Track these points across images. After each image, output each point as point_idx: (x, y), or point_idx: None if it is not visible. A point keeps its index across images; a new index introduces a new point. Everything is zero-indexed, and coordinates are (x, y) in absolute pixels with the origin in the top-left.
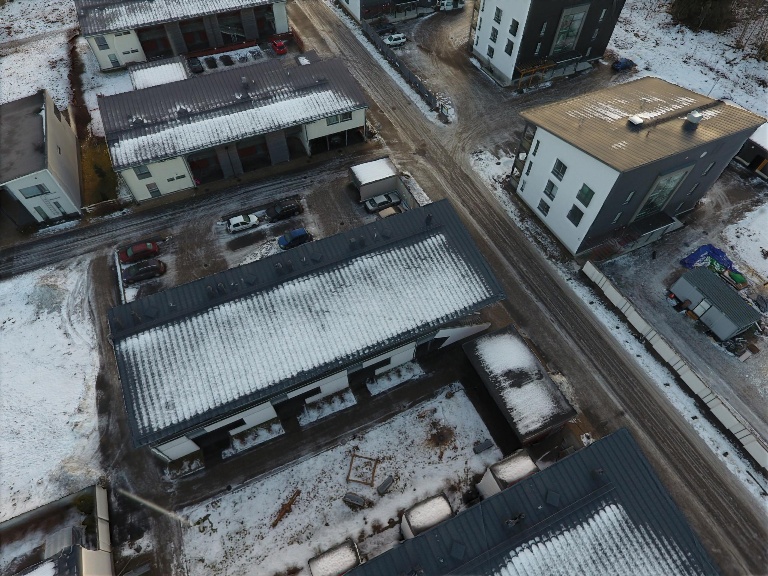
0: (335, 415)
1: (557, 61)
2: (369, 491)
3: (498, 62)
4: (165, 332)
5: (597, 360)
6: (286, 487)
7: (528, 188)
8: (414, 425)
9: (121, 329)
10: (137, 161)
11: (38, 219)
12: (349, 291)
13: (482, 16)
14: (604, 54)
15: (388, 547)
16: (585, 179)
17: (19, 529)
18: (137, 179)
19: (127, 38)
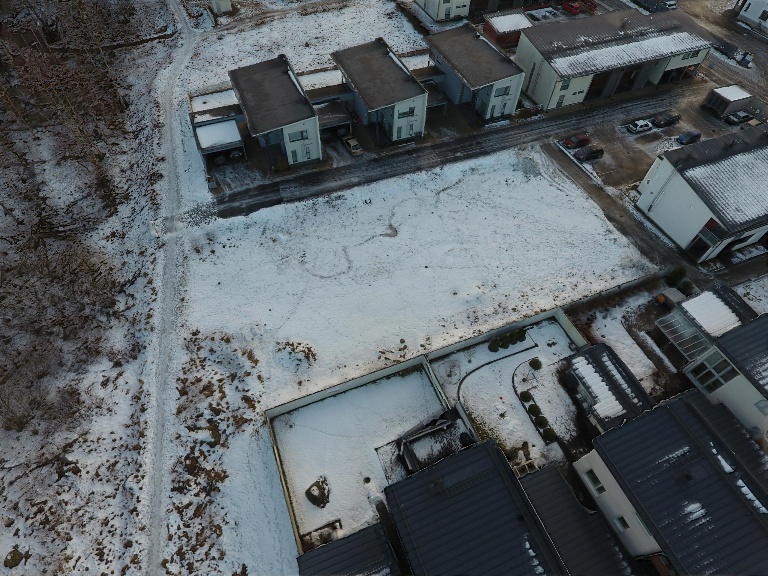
0: None
1: None
2: None
3: None
4: (710, 168)
5: None
6: None
7: None
8: None
9: None
10: (574, 73)
11: (487, 116)
12: None
13: None
14: None
15: None
16: None
17: (629, 291)
18: (559, 90)
19: None
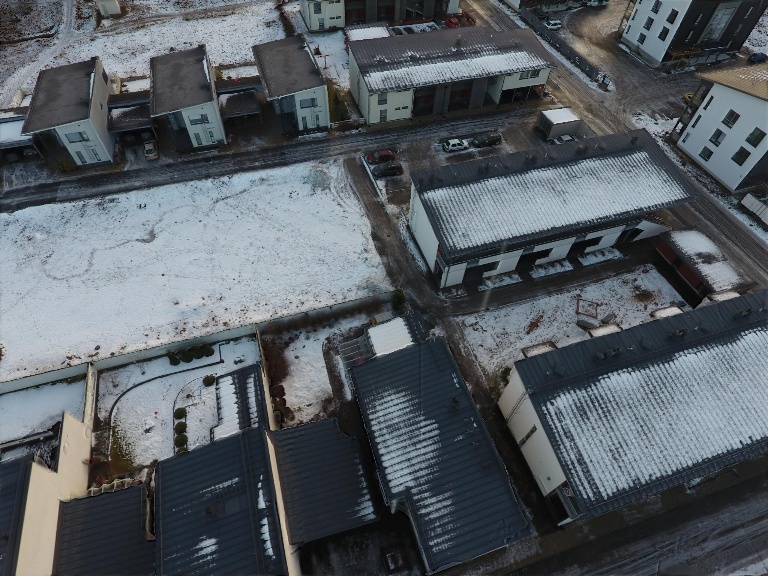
0: (558, 274)
1: (704, 48)
2: (595, 321)
3: (648, 47)
4: (453, 191)
5: (761, 262)
6: (531, 312)
7: (691, 139)
8: (621, 287)
9: (422, 185)
10: (385, 88)
11: (300, 127)
12: (580, 181)
13: (638, 8)
14: (740, 49)
15: (656, 318)
16: (758, 123)
17: (348, 312)
18: (377, 104)
19: (337, 6)
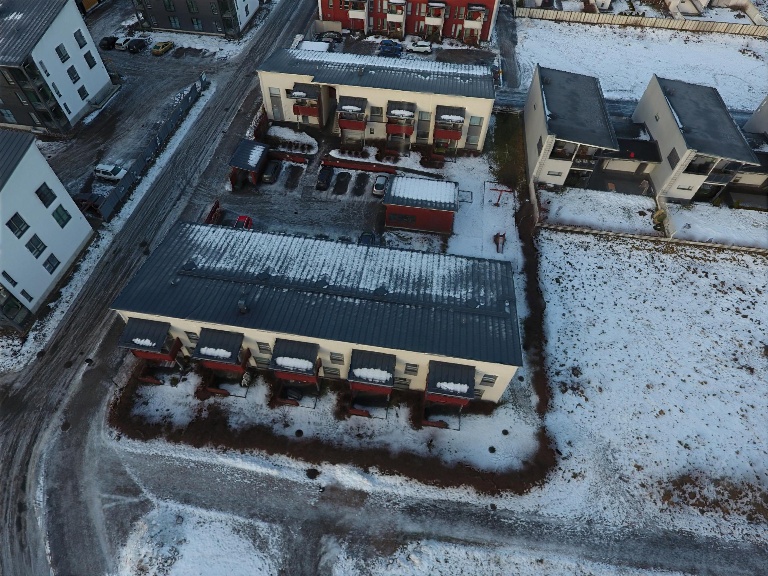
0: None
1: None
2: None
3: (93, 88)
4: None
5: None
6: None
7: None
8: None
9: None
10: None
11: None
12: None
13: (52, 80)
14: None
15: None
16: None
17: None
18: None
19: None
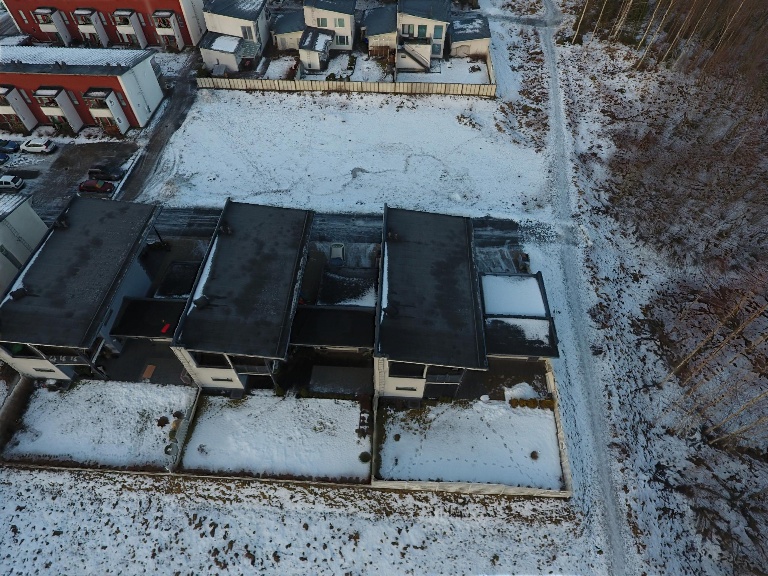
0: None
1: None
2: None
3: None
4: None
5: None
6: None
7: None
8: None
9: None
10: (6, 195)
11: None
12: (8, 57)
13: None
14: None
15: None
16: None
17: None
18: None
19: None
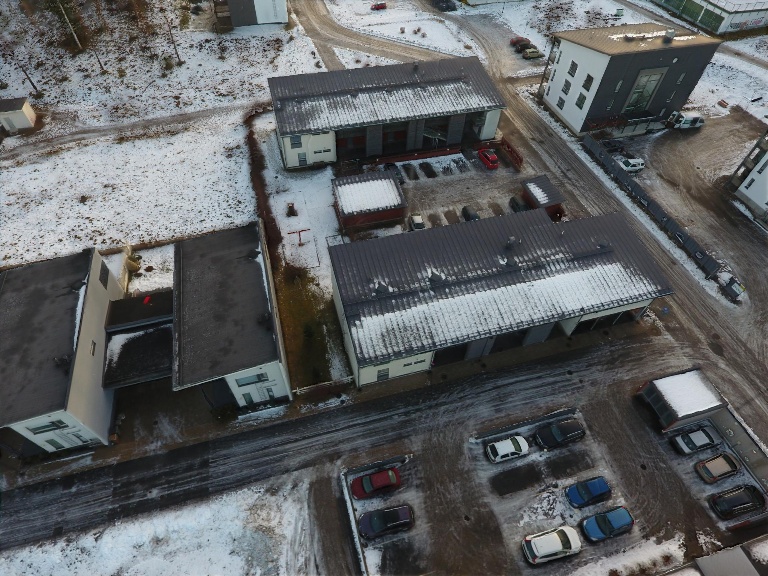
0: None
1: None
2: None
3: None
4: None
5: None
6: None
7: None
8: None
9: None
10: (387, 353)
11: (241, 403)
12: None
13: None
14: None
15: None
16: None
17: None
18: (372, 366)
19: (324, 137)
